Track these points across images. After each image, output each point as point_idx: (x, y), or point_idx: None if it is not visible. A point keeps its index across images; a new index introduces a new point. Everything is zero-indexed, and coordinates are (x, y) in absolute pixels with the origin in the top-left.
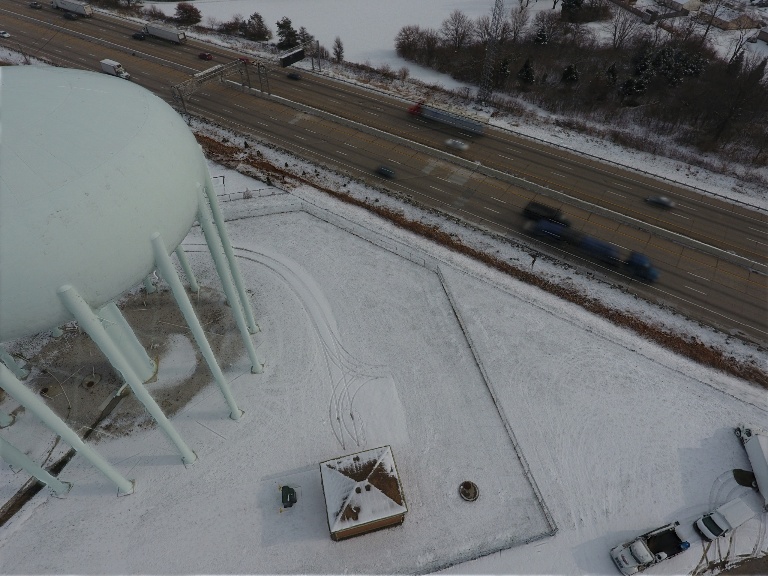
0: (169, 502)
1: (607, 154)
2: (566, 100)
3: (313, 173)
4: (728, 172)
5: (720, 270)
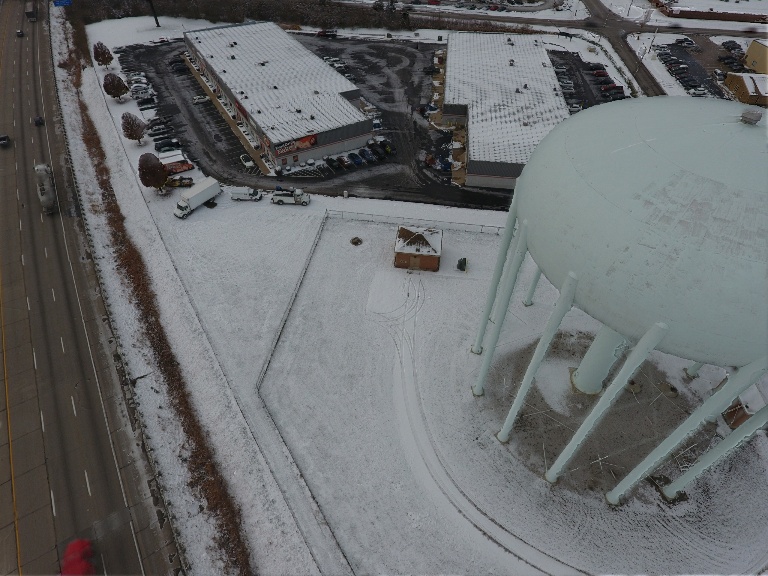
0: (537, 285)
1: None
2: None
3: None
4: None
5: (1, 301)
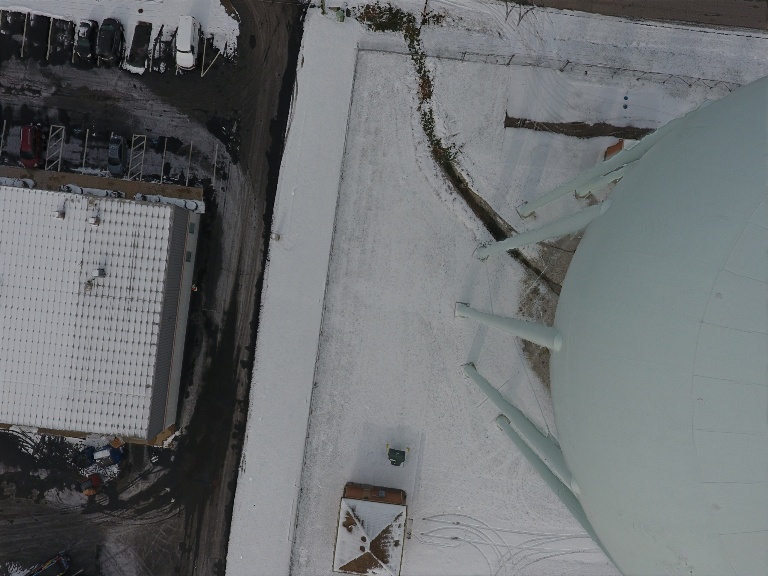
0: (434, 348)
1: None
2: None
3: None
4: None
5: None
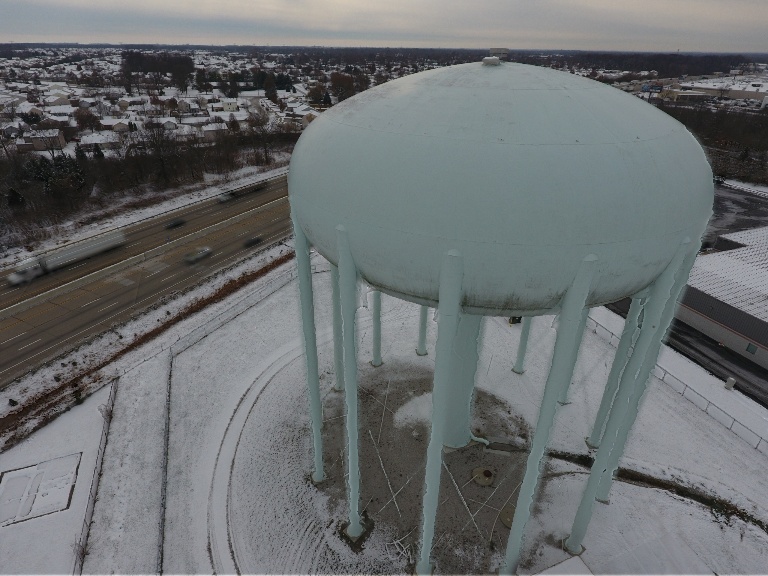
0: None
1: (156, 212)
2: (50, 212)
3: (65, 369)
4: (206, 186)
5: None
